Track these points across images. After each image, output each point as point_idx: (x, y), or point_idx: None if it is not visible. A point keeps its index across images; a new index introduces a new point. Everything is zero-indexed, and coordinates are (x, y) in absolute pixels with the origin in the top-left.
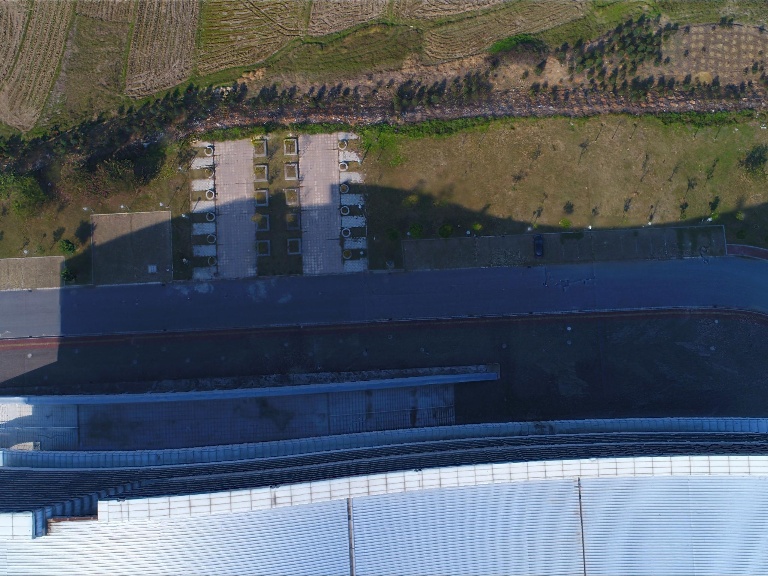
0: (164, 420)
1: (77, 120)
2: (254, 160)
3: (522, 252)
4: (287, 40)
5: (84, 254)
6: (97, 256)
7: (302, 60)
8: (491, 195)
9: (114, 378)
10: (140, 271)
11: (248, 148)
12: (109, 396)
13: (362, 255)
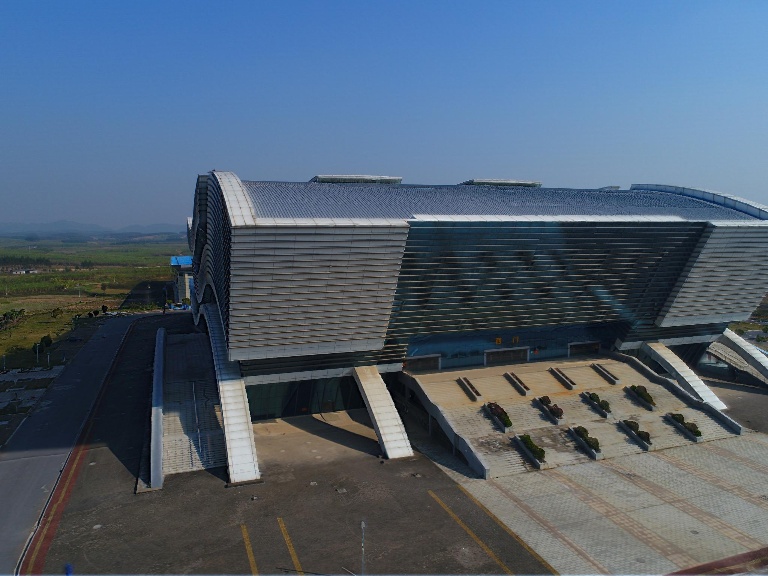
0: None
1: None
2: None
3: None
4: None
5: None
6: None
7: None
8: None
9: None
10: (2, 427)
11: None
12: None
13: (50, 366)
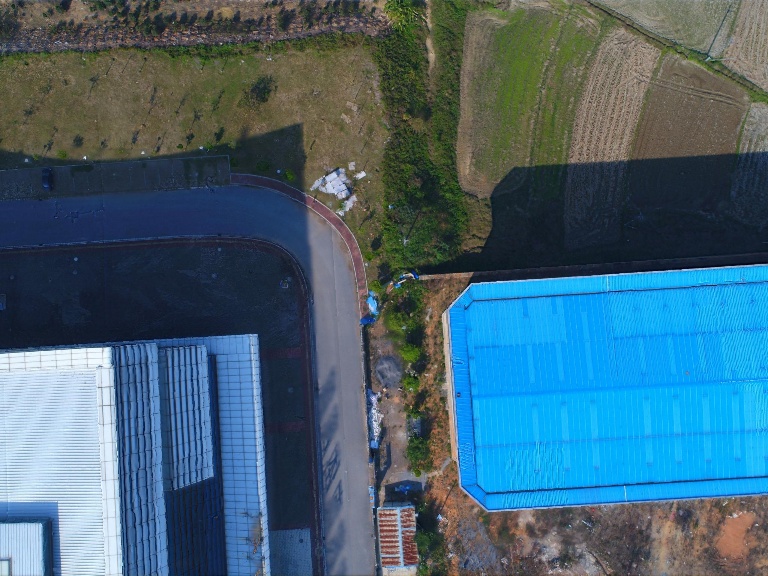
0: None
1: None
2: None
3: (33, 185)
4: None
5: None
6: None
7: None
8: (3, 130)
9: None
10: None
11: None
12: None
13: None
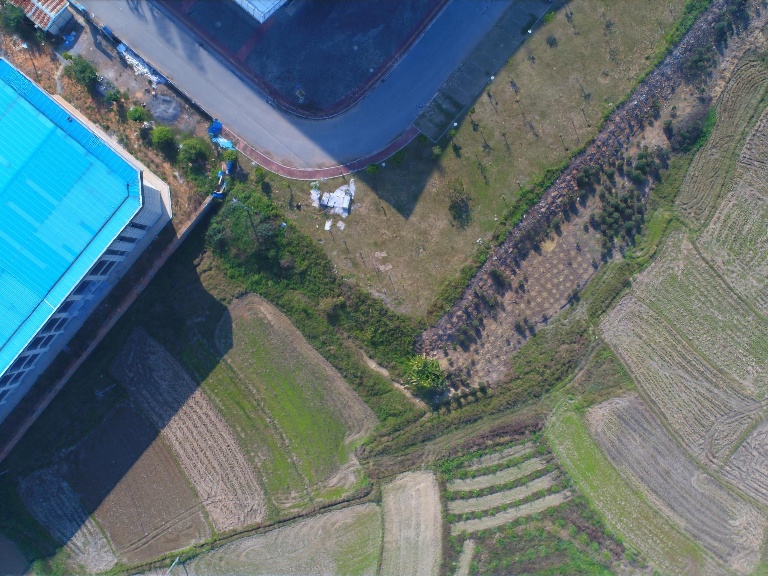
0: None
1: None
2: None
3: None
4: None
5: None
6: None
7: None
8: None
9: None
10: None
11: None
12: None
13: None
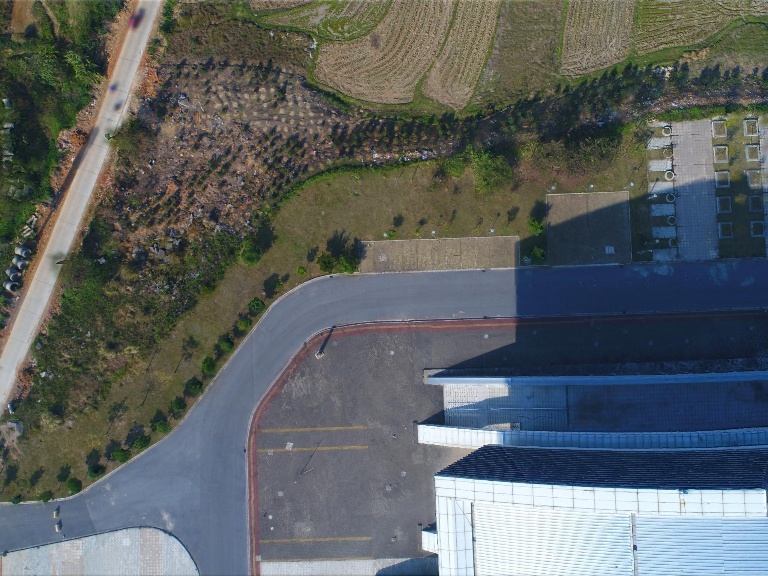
0: (656, 402)
1: (513, 99)
2: (713, 141)
3: None
4: (728, 20)
5: (540, 234)
6: (552, 236)
7: (745, 40)
8: None
9: (576, 360)
10: (597, 252)
11: (706, 128)
12: (612, 377)
13: None
